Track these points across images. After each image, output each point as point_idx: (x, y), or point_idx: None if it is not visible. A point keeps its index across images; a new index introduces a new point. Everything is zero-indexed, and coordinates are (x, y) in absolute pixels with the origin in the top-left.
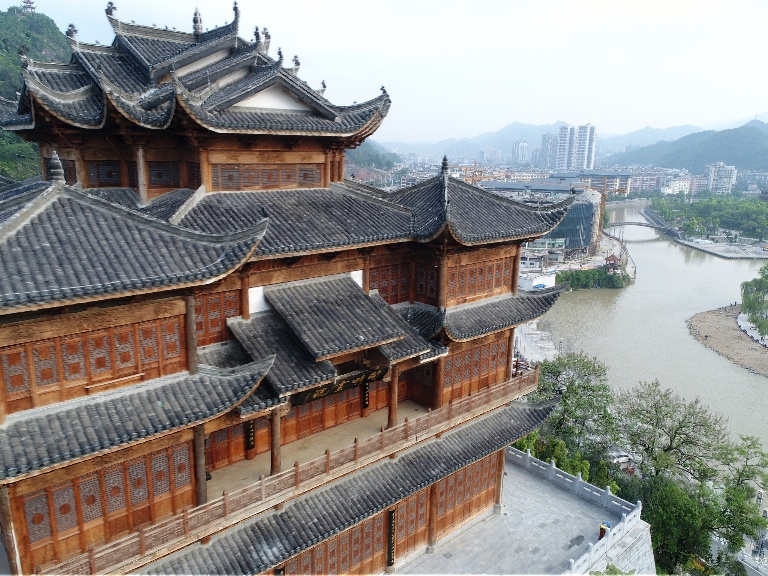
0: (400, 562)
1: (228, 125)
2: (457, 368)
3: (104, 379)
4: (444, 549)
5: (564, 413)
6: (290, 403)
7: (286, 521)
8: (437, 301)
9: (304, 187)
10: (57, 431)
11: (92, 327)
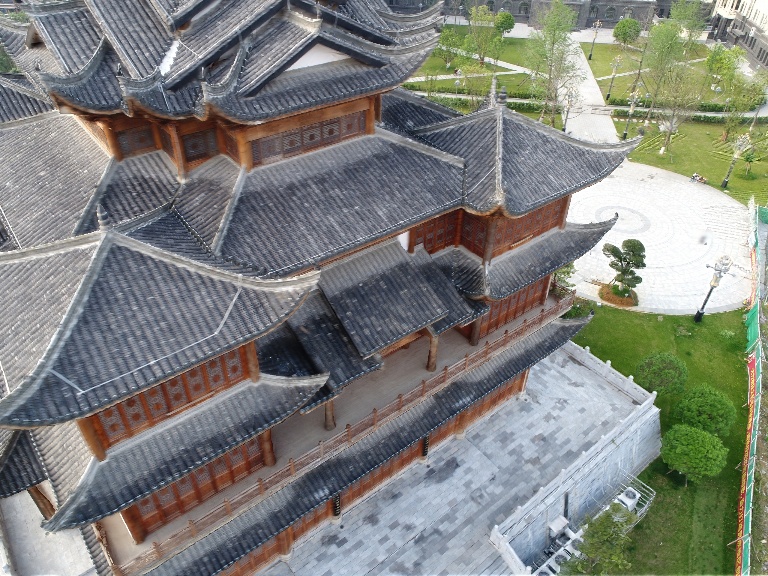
0: None
1: None
2: None
3: None
4: None
5: None
6: None
7: None
8: None
9: None
10: None
11: None
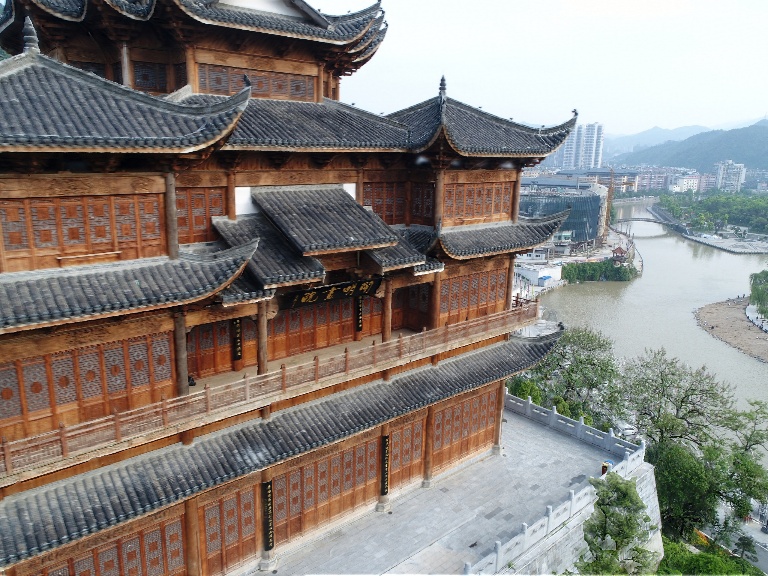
0: (394, 493)
1: (214, 16)
2: (454, 294)
3: (78, 252)
4: (440, 484)
5: (568, 386)
6: (277, 306)
7: (273, 430)
8: (433, 219)
9: (296, 100)
10: (25, 296)
11: (64, 192)
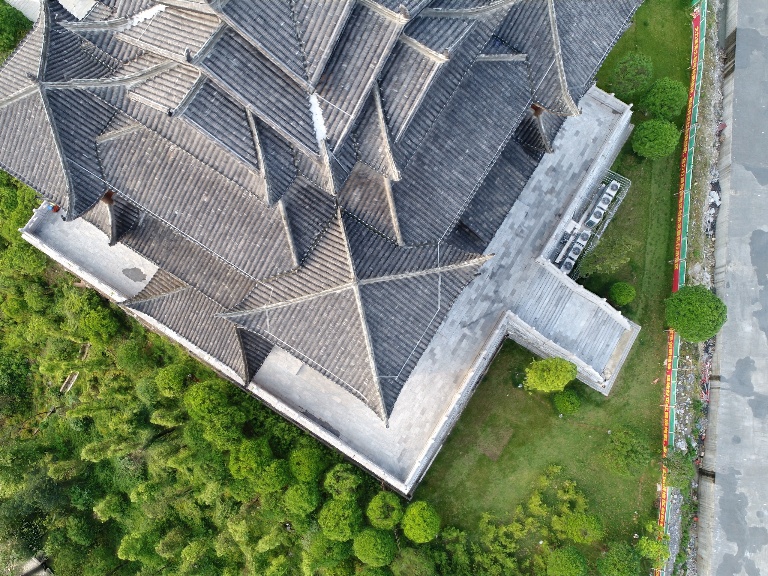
0: None
1: None
2: None
3: None
4: None
5: None
6: None
7: None
8: None
9: None
10: None
11: None
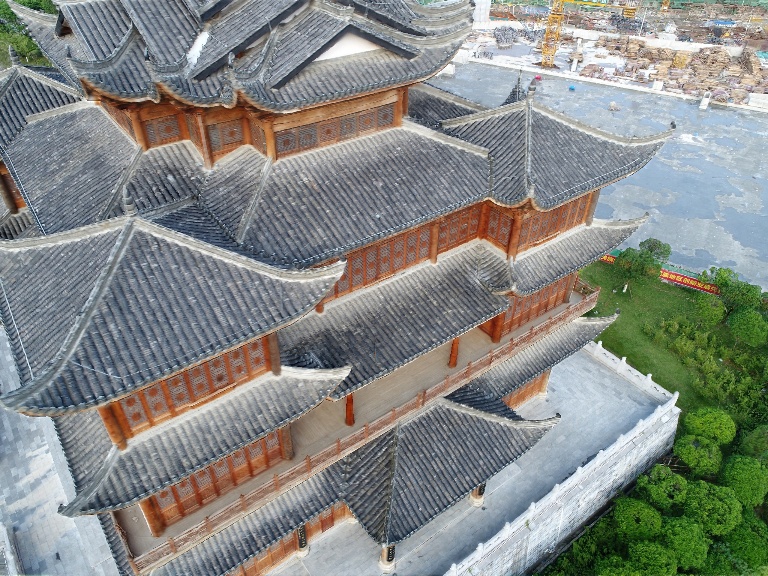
0: None
1: None
2: None
3: None
4: None
5: None
6: None
7: None
8: None
9: None
10: None
11: None
